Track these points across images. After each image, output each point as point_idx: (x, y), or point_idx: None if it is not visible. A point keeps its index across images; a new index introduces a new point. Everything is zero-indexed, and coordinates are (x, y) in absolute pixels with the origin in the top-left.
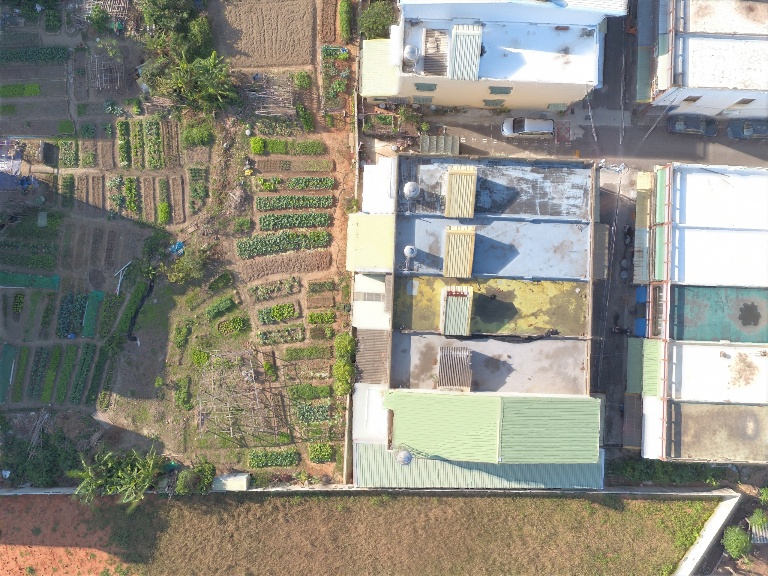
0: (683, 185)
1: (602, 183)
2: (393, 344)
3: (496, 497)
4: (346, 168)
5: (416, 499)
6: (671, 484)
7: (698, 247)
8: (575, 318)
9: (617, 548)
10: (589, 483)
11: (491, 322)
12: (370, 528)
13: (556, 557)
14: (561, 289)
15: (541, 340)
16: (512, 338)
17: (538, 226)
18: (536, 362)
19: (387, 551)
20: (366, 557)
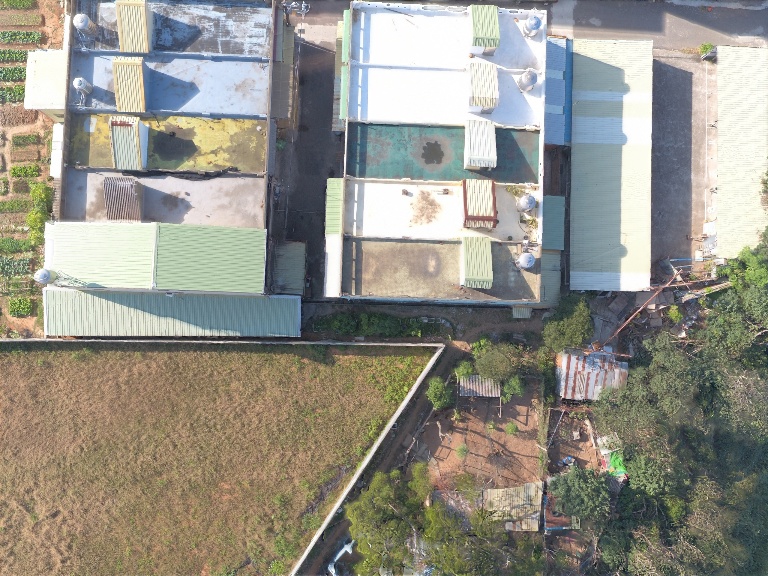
0: (367, 25)
1: (318, 41)
2: (69, 181)
3: (202, 351)
4: (55, 23)
5: (119, 353)
6: (384, 340)
7: (381, 86)
8: (256, 156)
9: (327, 404)
10: (286, 331)
11: (170, 159)
12: (72, 383)
13: (264, 413)
14: (242, 127)
15: (221, 177)
16: (190, 175)
17: (219, 64)
18: (215, 200)
19: (89, 406)
20: (67, 412)
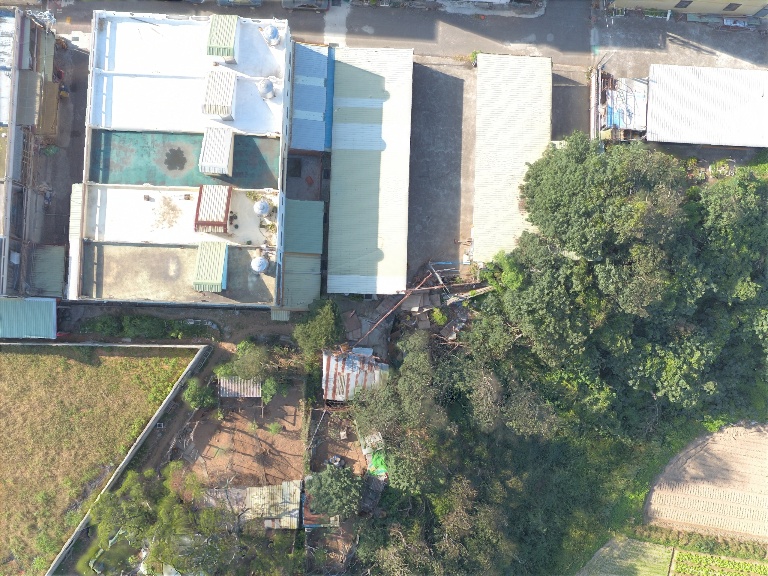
0: (112, 34)
1: None
2: None
3: None
4: None
5: None
6: (150, 341)
7: (125, 94)
8: (0, 162)
9: (92, 404)
10: (41, 333)
11: None
12: None
13: (29, 412)
14: None
15: None
16: None
17: None
18: None
19: None
20: None
